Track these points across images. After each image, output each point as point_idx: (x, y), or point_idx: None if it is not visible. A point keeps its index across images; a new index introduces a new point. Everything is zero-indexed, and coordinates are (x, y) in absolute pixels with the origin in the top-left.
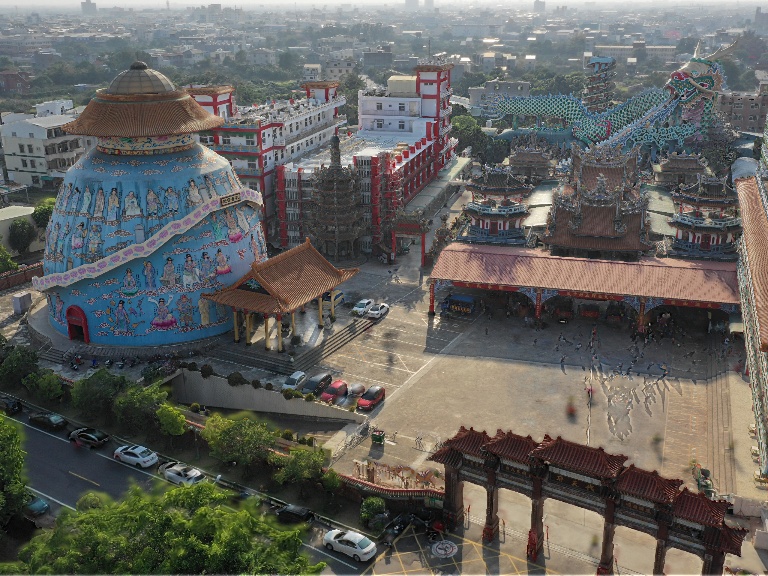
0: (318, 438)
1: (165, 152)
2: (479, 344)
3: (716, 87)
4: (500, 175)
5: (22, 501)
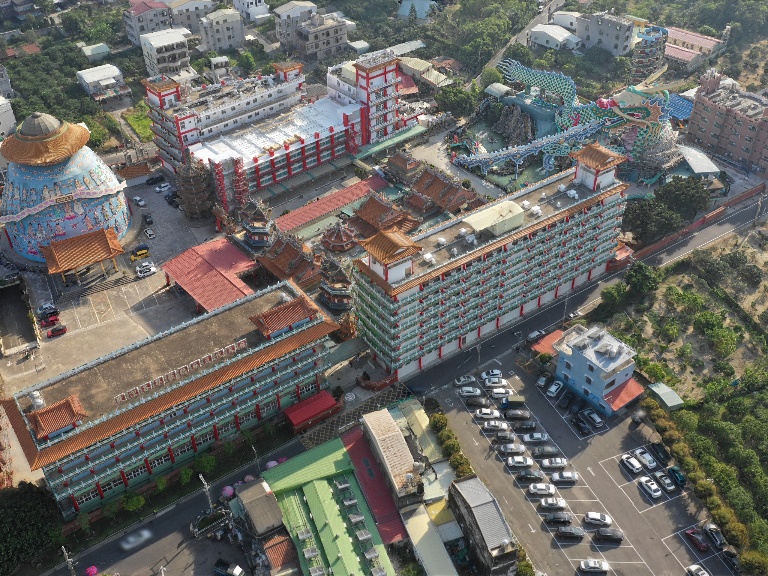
0: (17, 343)
1: (41, 165)
2: (153, 316)
3: (653, 118)
4: (255, 206)
5: None
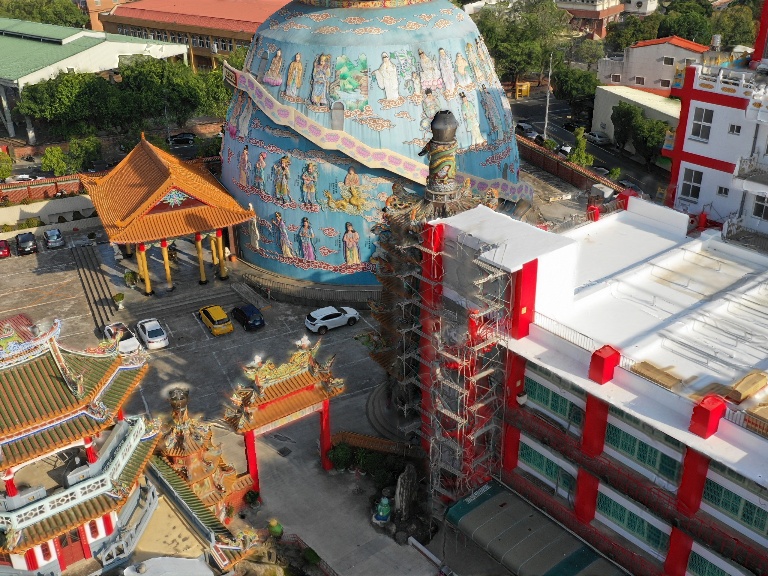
0: None
1: None
2: None
3: None
4: (5, 367)
5: None
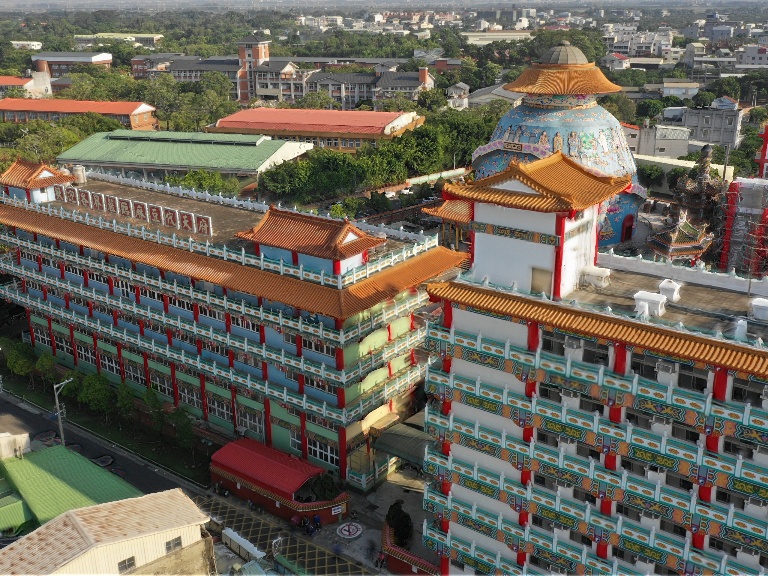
0: None
1: (529, 106)
2: None
3: None
4: None
5: (268, 187)
